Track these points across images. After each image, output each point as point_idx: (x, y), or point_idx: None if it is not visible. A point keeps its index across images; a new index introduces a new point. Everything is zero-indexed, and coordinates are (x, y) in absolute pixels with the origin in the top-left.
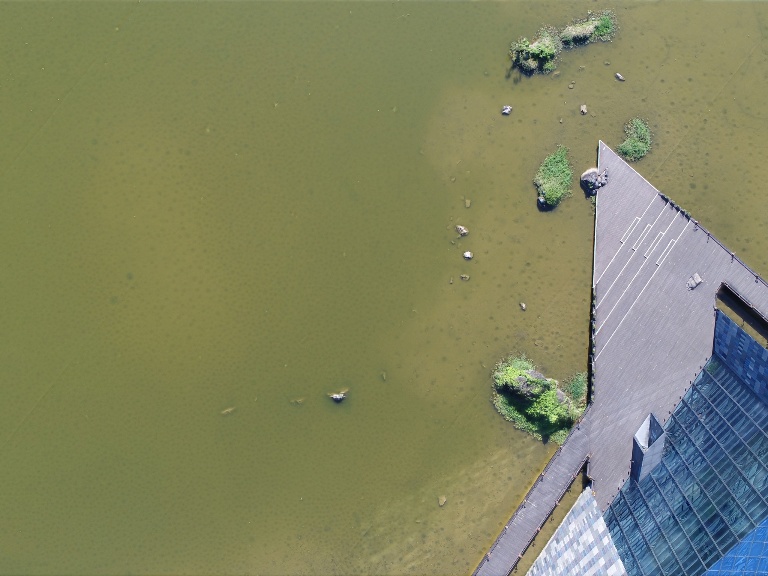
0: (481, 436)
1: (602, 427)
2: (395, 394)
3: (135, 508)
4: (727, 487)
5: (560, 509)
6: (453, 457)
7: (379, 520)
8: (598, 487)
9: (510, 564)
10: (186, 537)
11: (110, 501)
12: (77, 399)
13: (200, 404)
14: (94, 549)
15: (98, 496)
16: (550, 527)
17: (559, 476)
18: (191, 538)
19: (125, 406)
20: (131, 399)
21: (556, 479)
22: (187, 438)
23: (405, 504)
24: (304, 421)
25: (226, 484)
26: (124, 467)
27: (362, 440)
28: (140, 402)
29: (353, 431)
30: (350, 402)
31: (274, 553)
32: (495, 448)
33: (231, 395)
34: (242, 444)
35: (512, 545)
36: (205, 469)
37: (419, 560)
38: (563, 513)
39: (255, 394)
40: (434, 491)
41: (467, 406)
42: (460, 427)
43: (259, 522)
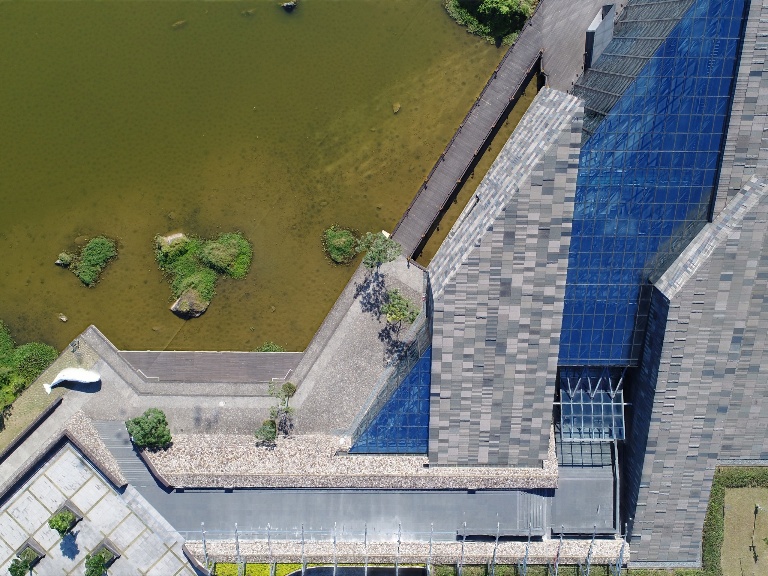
0: (434, 42)
1: (554, 22)
2: (346, 2)
3: (88, 125)
4: (672, 0)
5: (515, 113)
6: (406, 64)
7: (334, 130)
8: (552, 83)
9: (466, 163)
10: (140, 153)
11: (63, 118)
12: (26, 16)
13: (150, 18)
14: (48, 167)
15: (50, 114)
16: (506, 131)
17: (512, 73)
18: (145, 154)
19: (75, 23)
20: (81, 15)
21: (510, 76)
22: (138, 53)
23: (359, 113)
24: (256, 32)
25: (179, 98)
26: (76, 84)
27: (314, 50)
28: (90, 18)
29: (305, 41)
30: (301, 12)
31: (229, 166)
32: (448, 54)
33: (181, 8)
34: (194, 57)
35: (467, 144)
36: (157, 84)
37: (375, 169)
38: (518, 117)
39: (206, 7)
40: (388, 99)
41: (419, 11)
42: (412, 33)
43: (213, 135)
